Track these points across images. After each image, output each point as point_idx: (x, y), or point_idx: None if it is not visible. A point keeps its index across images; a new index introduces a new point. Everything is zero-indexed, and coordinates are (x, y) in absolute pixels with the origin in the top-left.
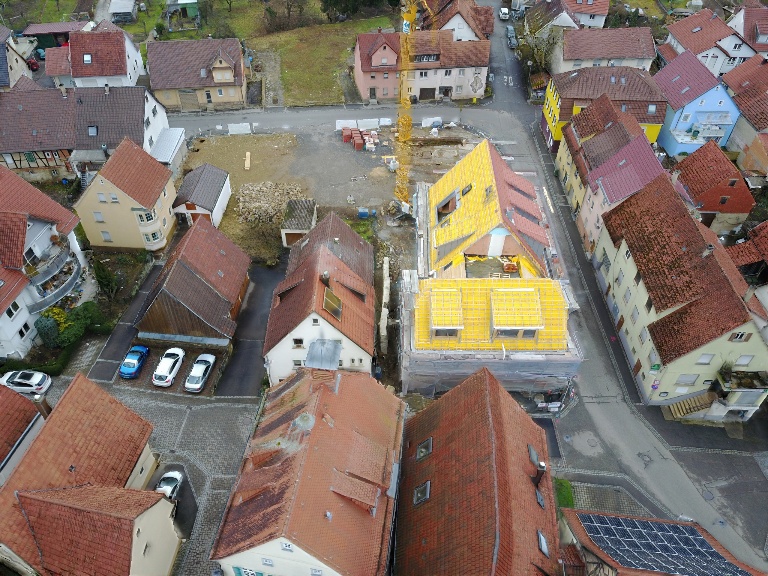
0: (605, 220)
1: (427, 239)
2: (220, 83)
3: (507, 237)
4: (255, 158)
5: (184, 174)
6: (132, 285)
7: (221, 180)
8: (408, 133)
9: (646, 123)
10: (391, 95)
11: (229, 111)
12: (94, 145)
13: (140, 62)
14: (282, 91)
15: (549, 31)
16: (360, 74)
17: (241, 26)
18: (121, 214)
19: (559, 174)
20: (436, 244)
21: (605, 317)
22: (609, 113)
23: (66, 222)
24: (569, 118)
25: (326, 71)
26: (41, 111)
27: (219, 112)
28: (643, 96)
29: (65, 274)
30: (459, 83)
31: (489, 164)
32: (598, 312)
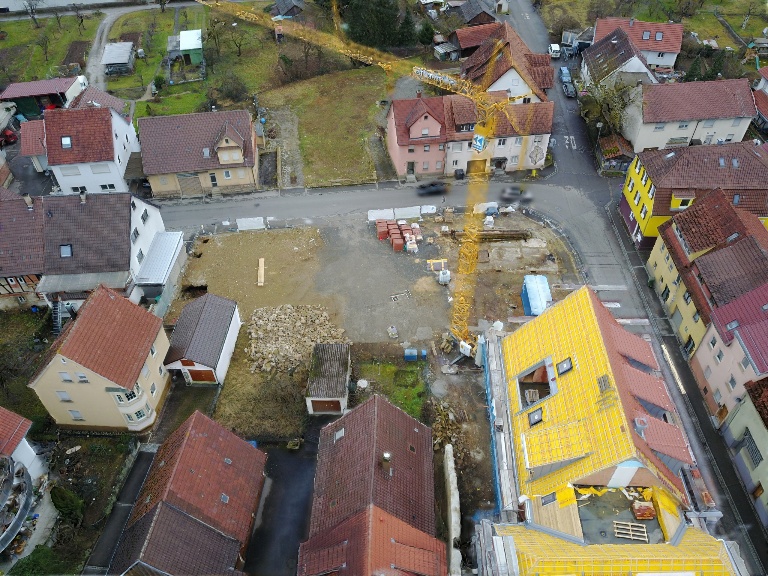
0: (752, 394)
1: (509, 434)
2: (227, 164)
3: (640, 469)
4: (270, 267)
5: (183, 290)
6: (108, 494)
7: (227, 316)
8: (472, 265)
9: (765, 216)
10: (432, 169)
11: (238, 196)
12: (68, 268)
13: (132, 136)
14: (301, 165)
15: (616, 78)
16: (395, 146)
17: (252, 74)
18: (93, 393)
19: (655, 285)
20: (529, 463)
21: (758, 536)
22: (730, 219)
23: (10, 434)
24: (665, 212)
25: (352, 135)
26: (1, 228)
27: (226, 197)
28: (762, 183)
29: (8, 511)
30: (515, 153)
31: (597, 334)
32: (746, 526)
